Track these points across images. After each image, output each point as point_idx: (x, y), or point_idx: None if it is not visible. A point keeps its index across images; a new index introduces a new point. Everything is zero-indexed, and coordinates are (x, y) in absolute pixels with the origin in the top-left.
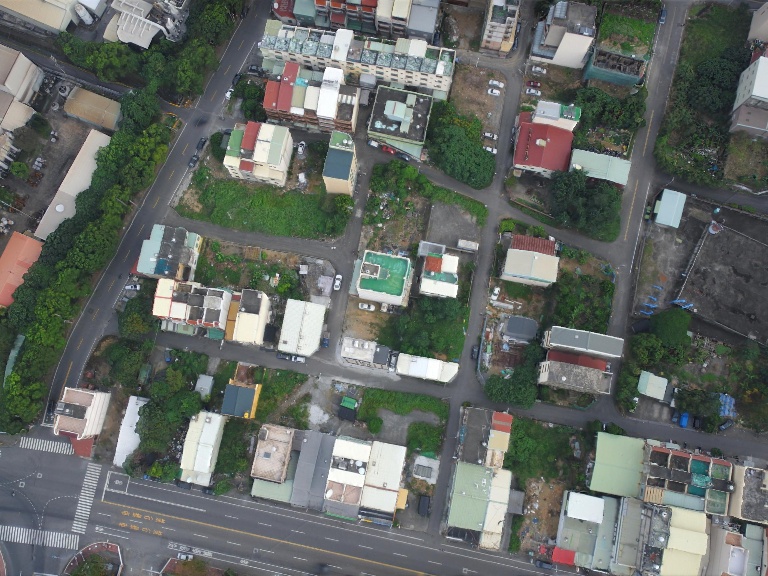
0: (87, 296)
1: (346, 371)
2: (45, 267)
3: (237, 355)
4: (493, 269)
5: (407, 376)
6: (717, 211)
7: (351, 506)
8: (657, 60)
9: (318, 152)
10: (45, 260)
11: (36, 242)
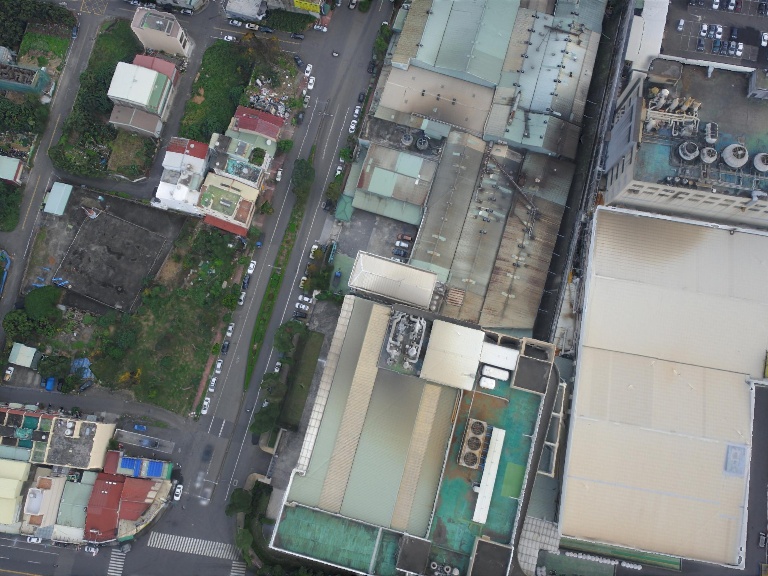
0: None
1: None
2: None
3: None
4: None
5: None
6: (99, 198)
7: None
8: (68, 70)
9: None
10: None
11: None
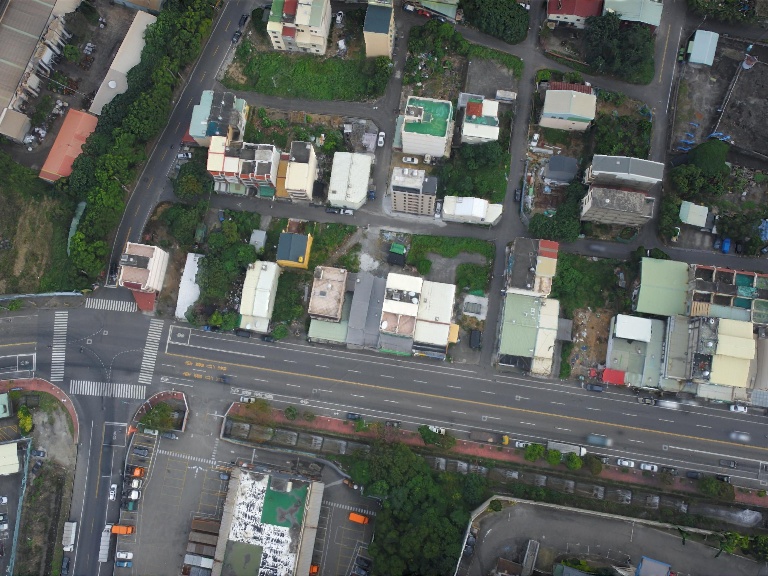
0: (142, 166)
1: (393, 221)
2: (102, 136)
3: (287, 212)
4: (531, 117)
5: (453, 222)
6: (750, 48)
7: (405, 341)
8: None
9: (356, 19)
10: (102, 129)
11: (91, 117)
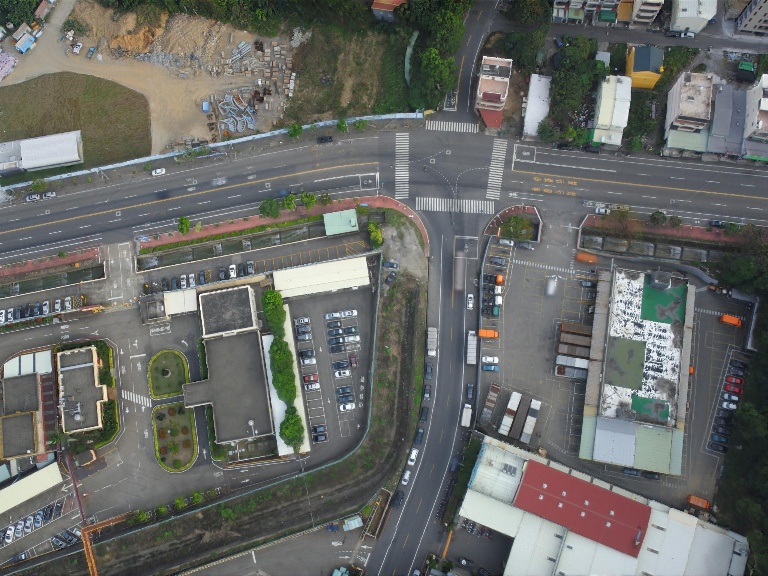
0: None
1: (736, 42)
2: None
3: (625, 38)
4: None
5: None
6: None
7: None
8: None
9: None
10: None
11: None
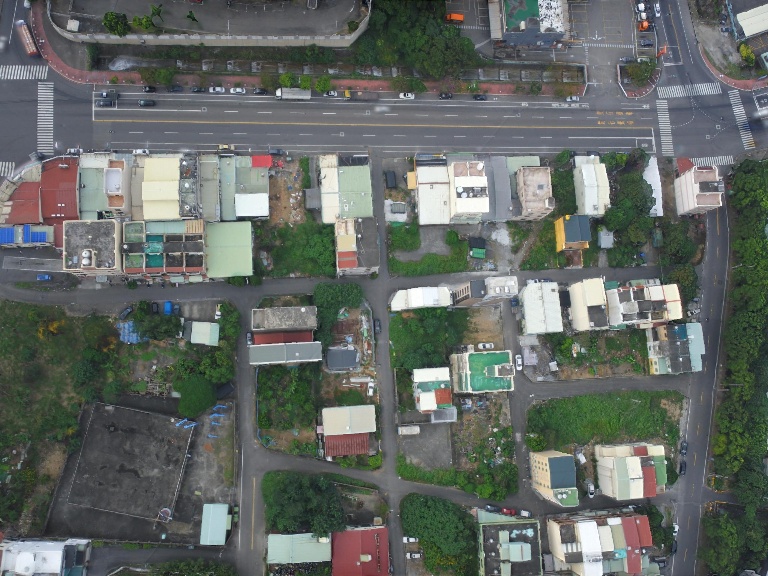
0: None
1: None
2: None
3: (586, 274)
4: (379, 413)
5: None
6: (165, 535)
7: None
8: None
9: None
10: None
11: None
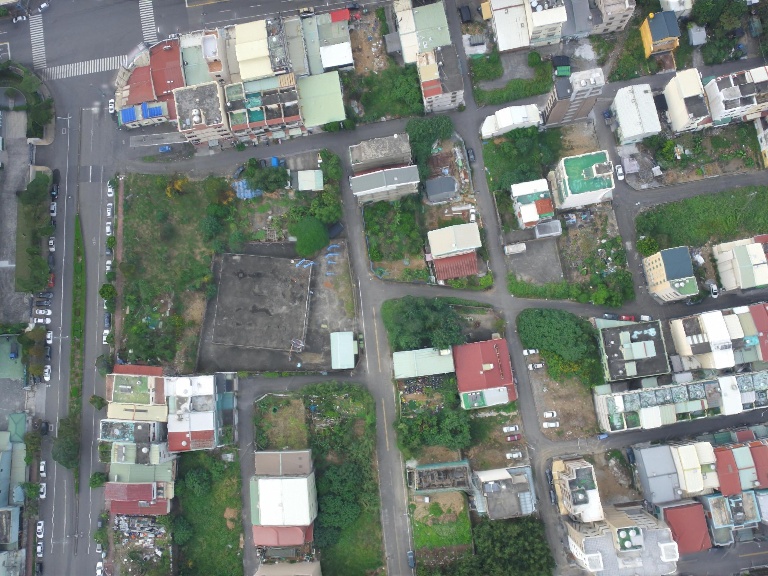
0: None
1: None
2: None
3: None
4: (483, 237)
5: None
6: None
7: None
8: (401, 508)
9: None
10: None
11: None
